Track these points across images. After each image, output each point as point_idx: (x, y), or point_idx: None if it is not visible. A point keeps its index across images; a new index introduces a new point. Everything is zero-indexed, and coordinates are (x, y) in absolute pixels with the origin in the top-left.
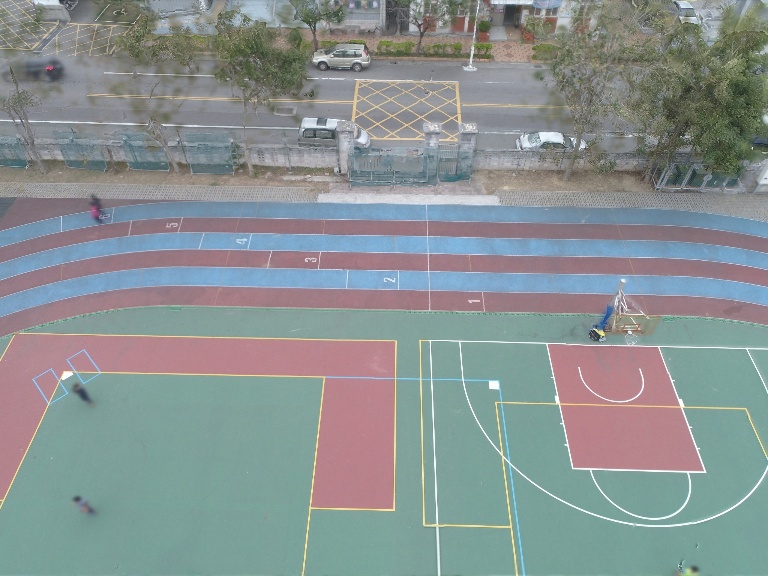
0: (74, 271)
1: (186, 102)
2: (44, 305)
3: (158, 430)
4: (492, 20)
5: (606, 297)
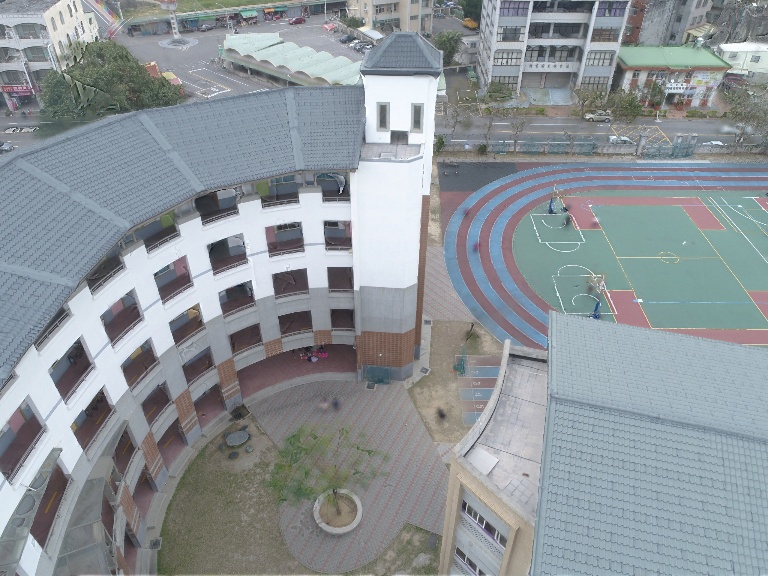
0: None
1: (540, 134)
2: None
3: None
4: (661, 100)
5: (767, 187)
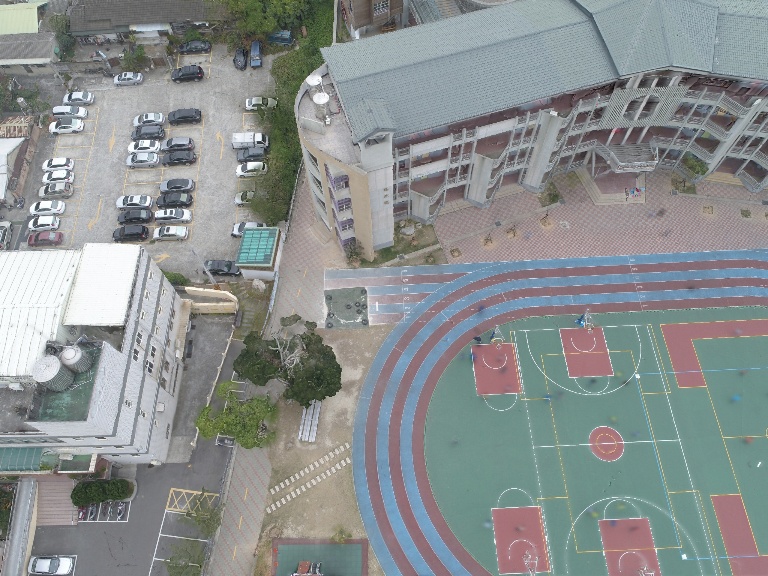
0: None
1: None
2: None
3: None
4: None
5: None
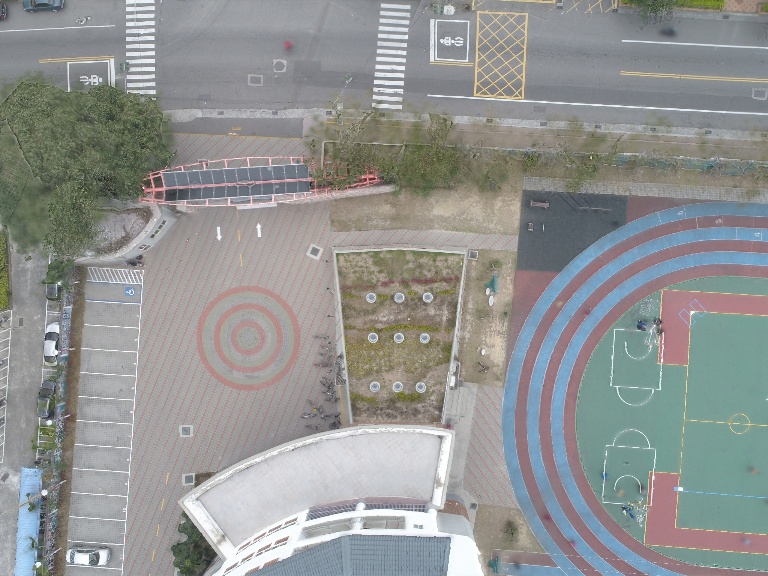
0: (677, 253)
1: (691, 83)
2: (669, 273)
3: (738, 340)
4: None
5: None
